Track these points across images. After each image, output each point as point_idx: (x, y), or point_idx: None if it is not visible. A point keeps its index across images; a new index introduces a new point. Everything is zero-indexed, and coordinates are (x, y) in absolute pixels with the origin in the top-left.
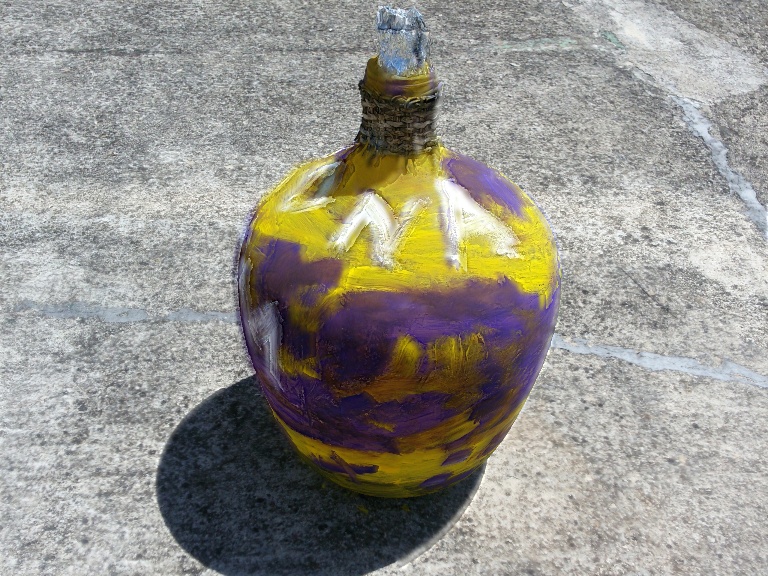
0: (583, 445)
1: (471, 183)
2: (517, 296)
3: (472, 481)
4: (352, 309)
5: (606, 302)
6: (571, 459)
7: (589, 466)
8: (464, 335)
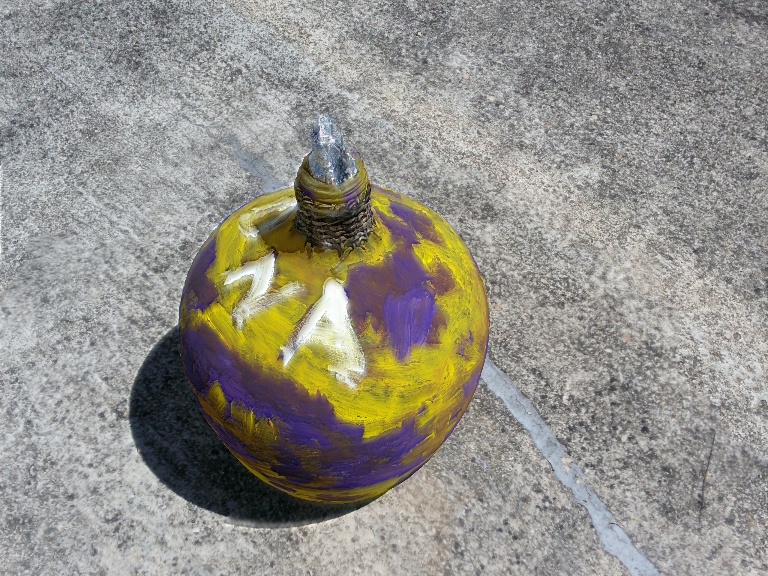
0: (457, 556)
1: (360, 293)
2: (322, 412)
3: (341, 508)
4: (197, 332)
5: (652, 454)
6: (432, 557)
7: (438, 575)
8: (257, 411)
